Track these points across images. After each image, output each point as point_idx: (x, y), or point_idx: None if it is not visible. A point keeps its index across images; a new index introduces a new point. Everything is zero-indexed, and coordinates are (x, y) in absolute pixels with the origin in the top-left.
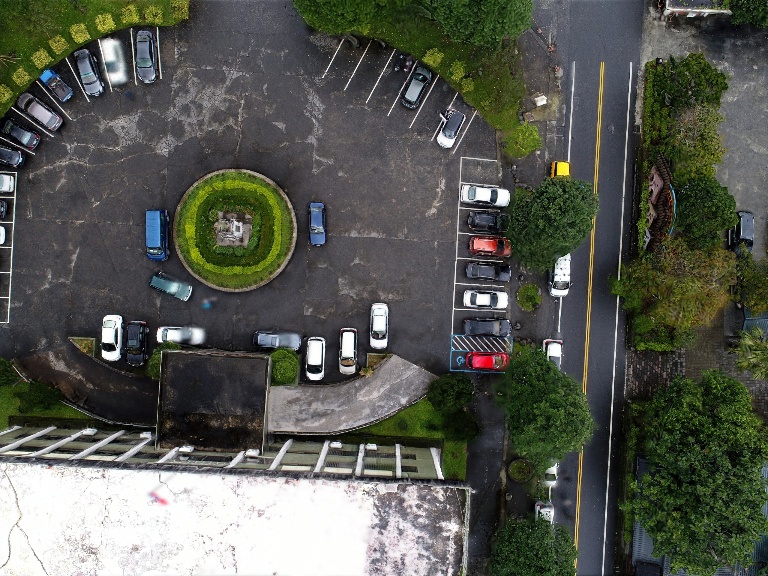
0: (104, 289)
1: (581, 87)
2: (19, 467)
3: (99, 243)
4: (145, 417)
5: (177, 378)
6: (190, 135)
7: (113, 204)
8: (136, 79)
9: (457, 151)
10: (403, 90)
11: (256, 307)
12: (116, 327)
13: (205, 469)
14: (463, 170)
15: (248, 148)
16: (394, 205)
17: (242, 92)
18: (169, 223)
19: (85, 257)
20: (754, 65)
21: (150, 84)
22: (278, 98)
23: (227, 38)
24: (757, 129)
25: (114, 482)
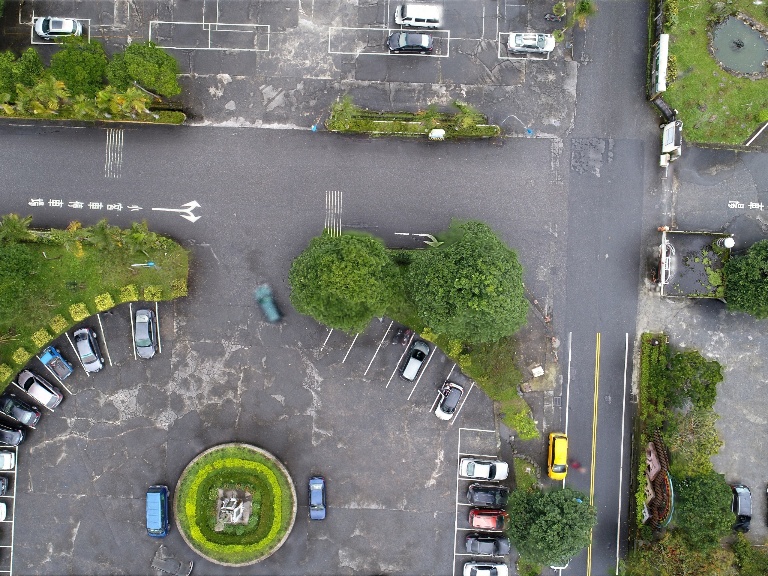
0: (105, 562)
1: (578, 358)
2: None
3: (100, 517)
4: None
5: None
6: (190, 409)
7: (113, 478)
8: (135, 353)
9: (455, 422)
10: (401, 362)
11: None
12: None
13: None
14: (461, 441)
15: (247, 421)
16: (393, 476)
17: (241, 365)
18: (169, 497)
19: (86, 531)
20: (749, 336)
21: (149, 358)
22: (277, 371)
23: (226, 312)
24: (753, 399)
25: None
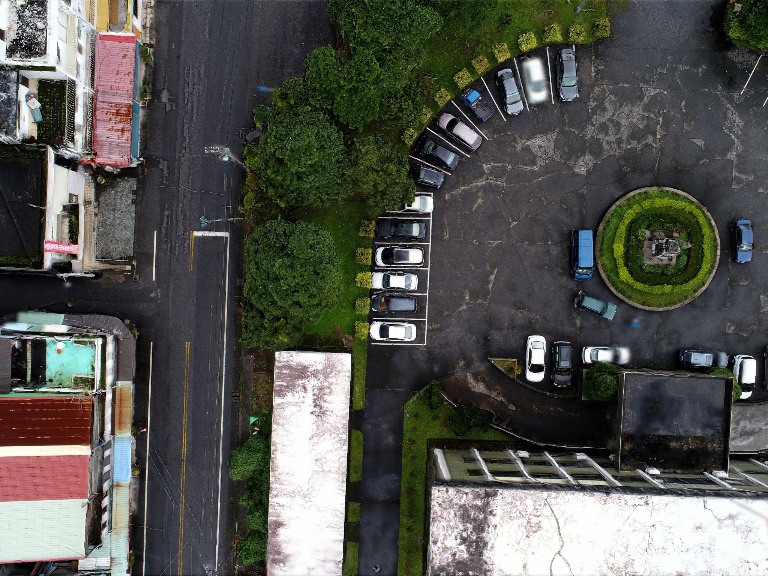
0: (523, 309)
1: None
2: (561, 495)
3: (517, 263)
4: (572, 438)
5: (636, 400)
6: (608, 153)
7: (531, 224)
8: (553, 98)
9: None
10: None
11: (677, 325)
12: (544, 348)
13: (753, 495)
14: None
15: (667, 165)
16: None
17: (660, 109)
18: None
19: (503, 277)
20: None
21: (567, 102)
22: (696, 115)
23: (644, 55)
24: None
25: (658, 509)
